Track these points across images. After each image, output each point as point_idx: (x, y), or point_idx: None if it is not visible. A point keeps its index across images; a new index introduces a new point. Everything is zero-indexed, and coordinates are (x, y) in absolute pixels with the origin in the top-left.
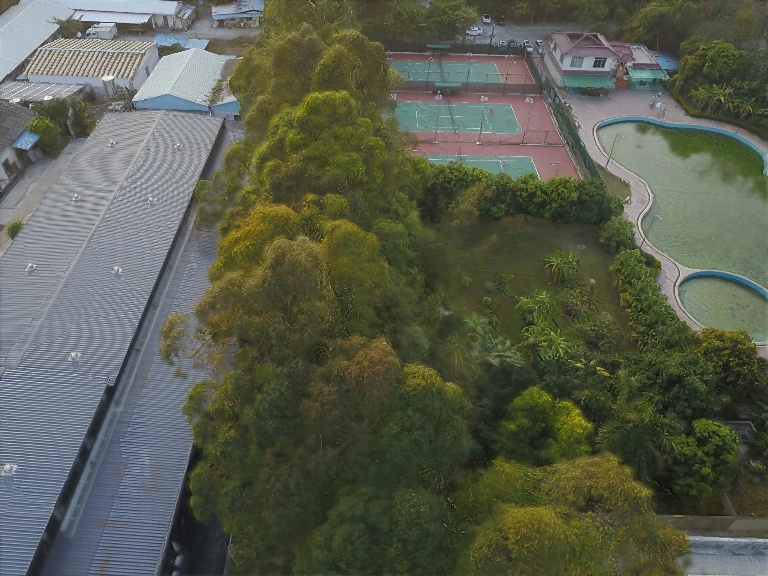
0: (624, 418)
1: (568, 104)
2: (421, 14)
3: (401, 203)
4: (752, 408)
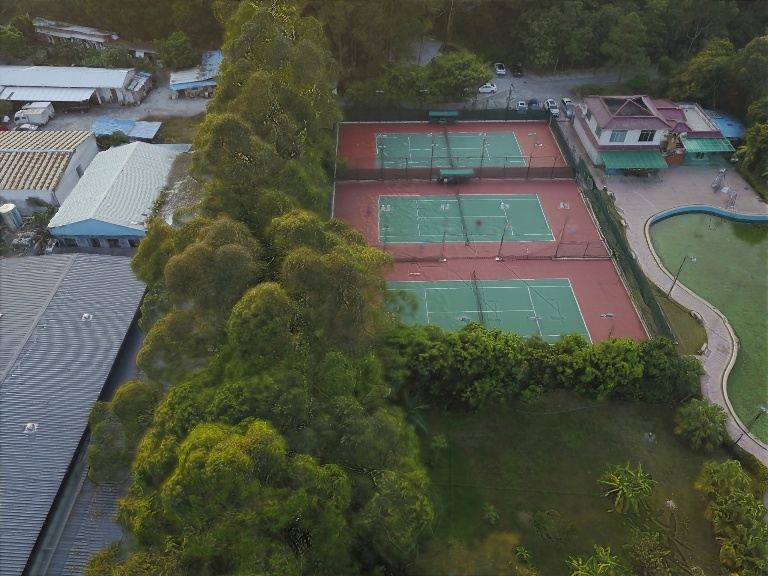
0: None
1: (609, 192)
2: (421, 78)
3: None
4: None
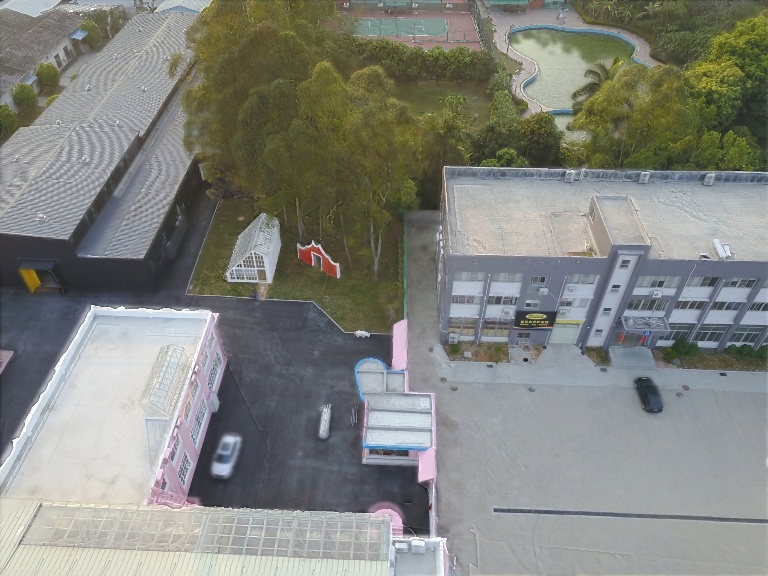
0: None
1: (490, 17)
2: None
3: None
4: None
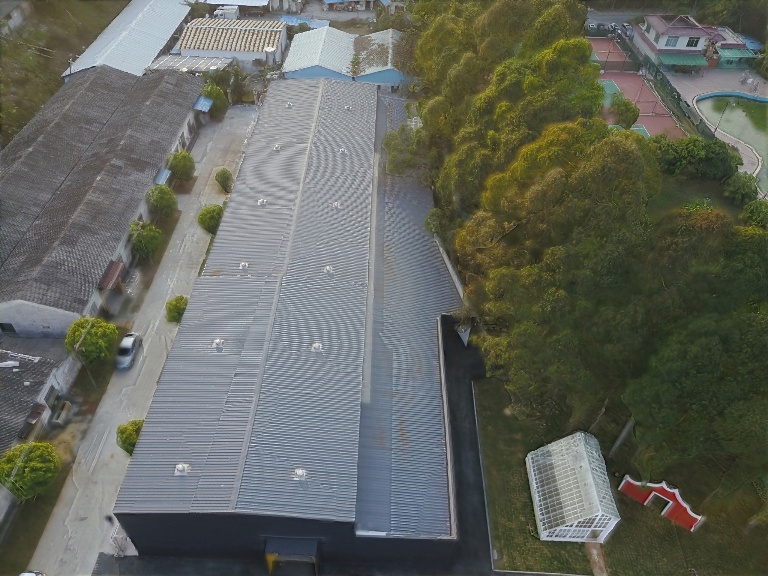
0: None
1: None
2: None
3: None
4: None
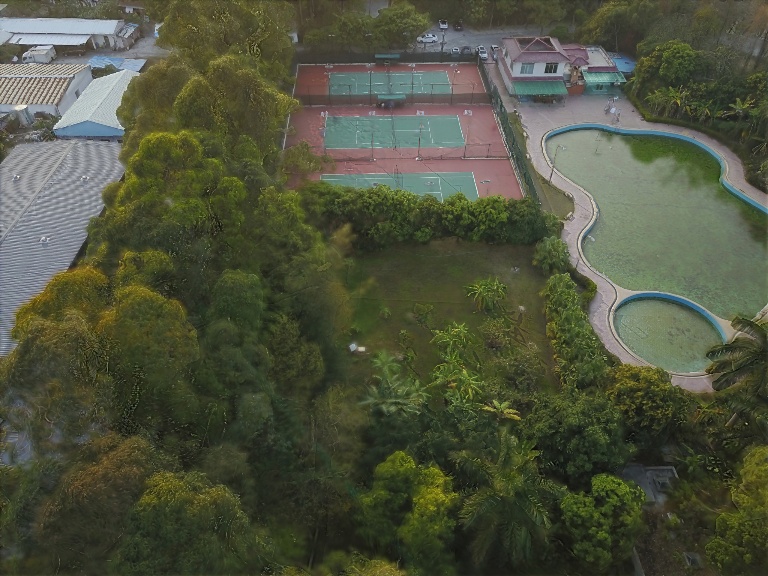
0: (497, 485)
1: (518, 113)
2: (367, 24)
3: (302, 235)
4: (677, 451)
